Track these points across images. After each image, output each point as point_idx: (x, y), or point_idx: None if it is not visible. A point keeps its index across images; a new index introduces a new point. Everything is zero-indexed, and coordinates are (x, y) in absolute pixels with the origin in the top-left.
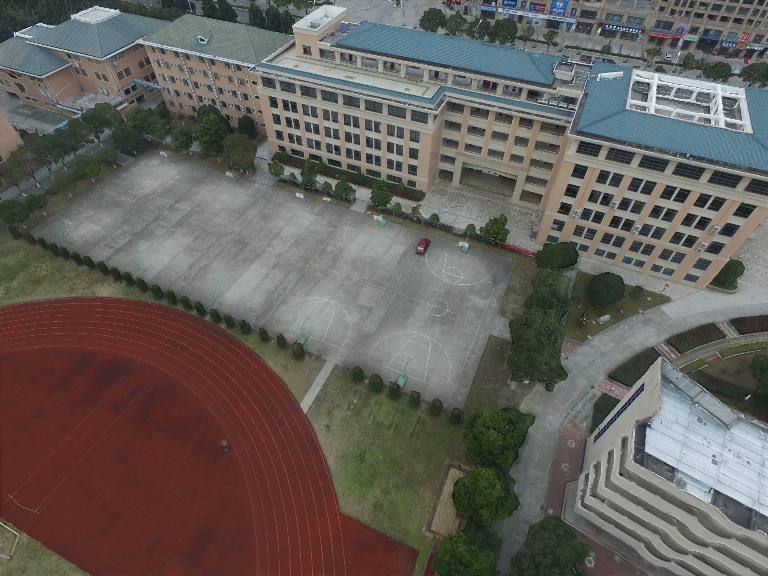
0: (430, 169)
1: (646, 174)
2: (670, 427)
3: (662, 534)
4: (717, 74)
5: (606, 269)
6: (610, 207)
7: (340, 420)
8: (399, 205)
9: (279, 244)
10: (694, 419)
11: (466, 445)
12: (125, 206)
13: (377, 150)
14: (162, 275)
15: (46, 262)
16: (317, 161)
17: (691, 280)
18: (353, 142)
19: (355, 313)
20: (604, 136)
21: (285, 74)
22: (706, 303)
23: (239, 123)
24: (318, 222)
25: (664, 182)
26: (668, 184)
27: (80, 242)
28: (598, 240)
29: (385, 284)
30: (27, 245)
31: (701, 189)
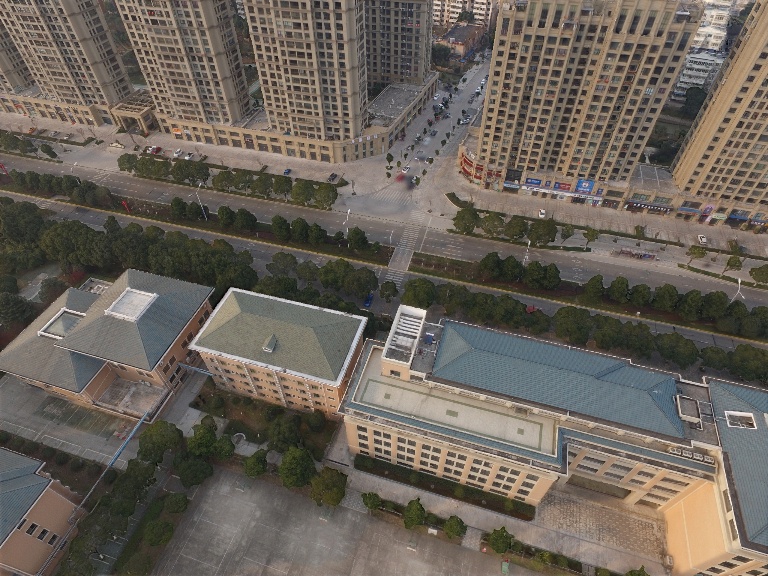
0: None
1: None
2: None
3: None
4: (767, 280)
5: None
6: None
7: None
8: (520, 545)
9: None
10: None
11: None
12: None
13: (483, 475)
14: None
15: None
16: (406, 466)
17: None
18: (455, 465)
19: None
20: None
21: (382, 417)
22: None
23: (311, 422)
24: None
25: None
26: None
27: None
28: None
29: None
30: None
31: None
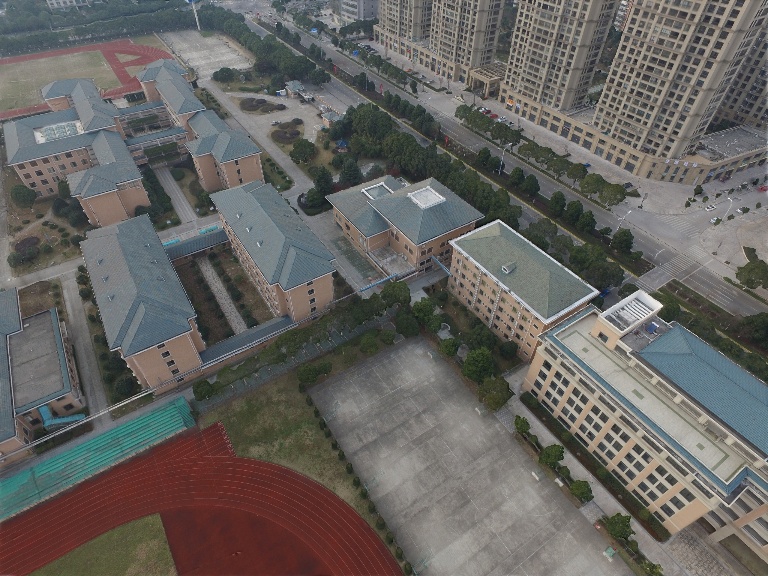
0: None
1: None
2: None
3: None
4: None
5: None
6: None
7: None
8: (636, 546)
9: (497, 520)
10: None
11: None
12: (383, 395)
13: (635, 468)
14: (389, 499)
15: (313, 430)
16: (564, 425)
17: None
18: (612, 444)
19: None
20: None
21: (572, 360)
22: None
23: (504, 346)
24: (542, 511)
25: None
26: None
27: (341, 421)
28: None
29: None
30: (305, 403)
31: None
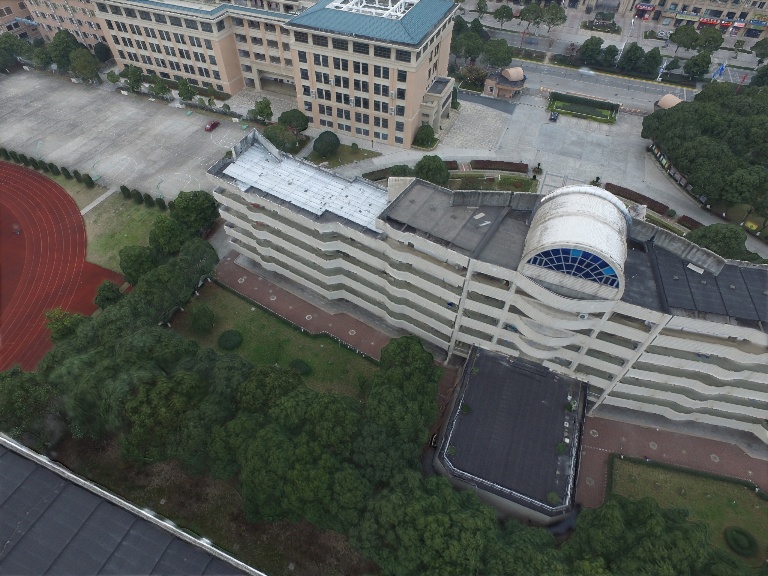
0: (230, 74)
1: (338, 53)
2: (246, 163)
3: (260, 241)
4: (500, 15)
5: (345, 139)
6: (329, 84)
7: (105, 218)
8: (201, 99)
9: (102, 126)
10: (263, 160)
11: (170, 214)
12: None
13: (189, 60)
14: (5, 144)
15: None
16: None
17: (400, 142)
18: (171, 55)
19: (143, 164)
20: (305, 25)
21: None
22: (406, 157)
23: (94, 48)
24: (139, 113)
25: (351, 59)
26: (353, 60)
27: None
28: (335, 115)
29: (173, 148)
30: None
31: (372, 61)
